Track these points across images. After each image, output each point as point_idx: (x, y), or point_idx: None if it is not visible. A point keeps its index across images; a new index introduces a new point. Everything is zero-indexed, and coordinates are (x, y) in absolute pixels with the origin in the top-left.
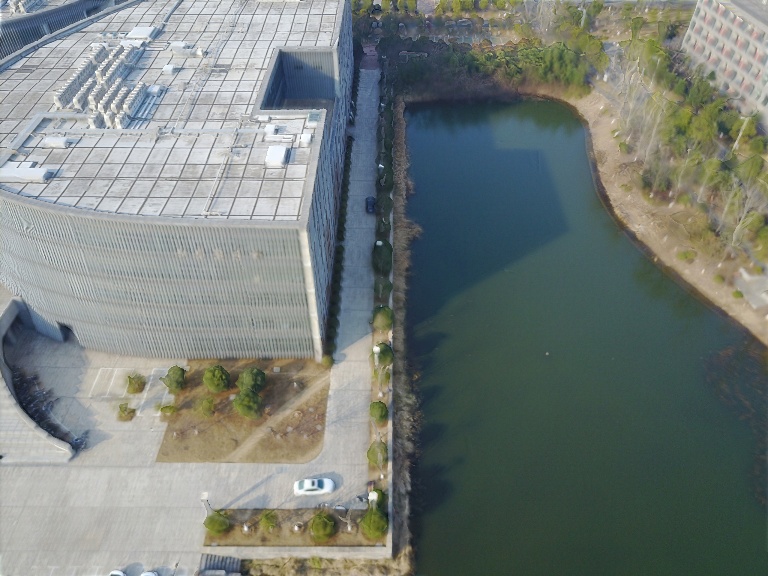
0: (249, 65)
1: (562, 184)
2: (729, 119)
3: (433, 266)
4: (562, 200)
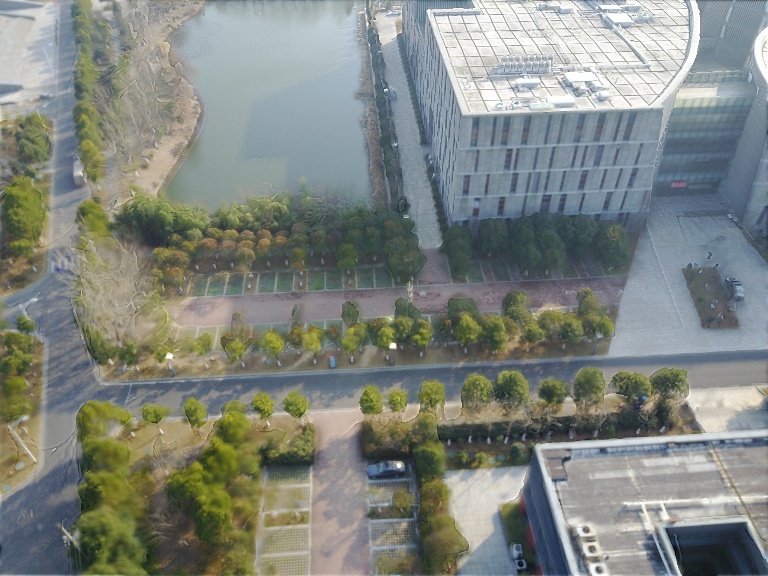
0: (494, 4)
1: (227, 138)
2: (38, 131)
3: (346, 78)
4: (236, 122)
